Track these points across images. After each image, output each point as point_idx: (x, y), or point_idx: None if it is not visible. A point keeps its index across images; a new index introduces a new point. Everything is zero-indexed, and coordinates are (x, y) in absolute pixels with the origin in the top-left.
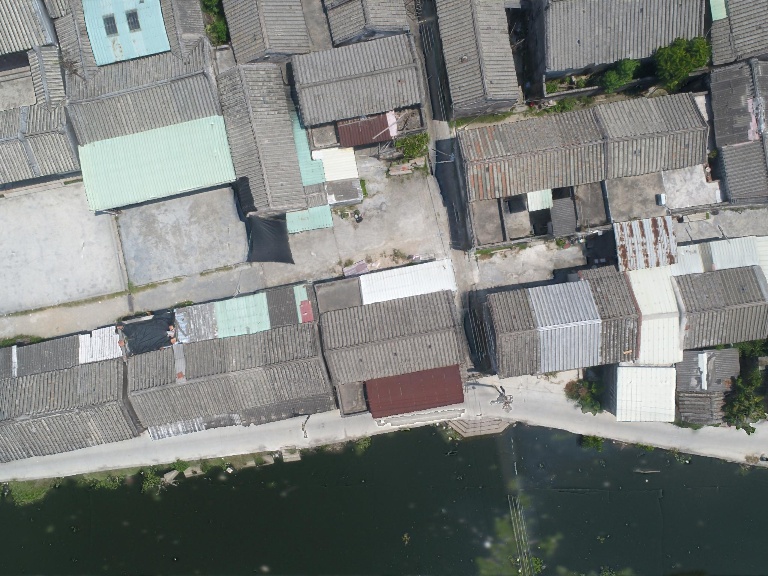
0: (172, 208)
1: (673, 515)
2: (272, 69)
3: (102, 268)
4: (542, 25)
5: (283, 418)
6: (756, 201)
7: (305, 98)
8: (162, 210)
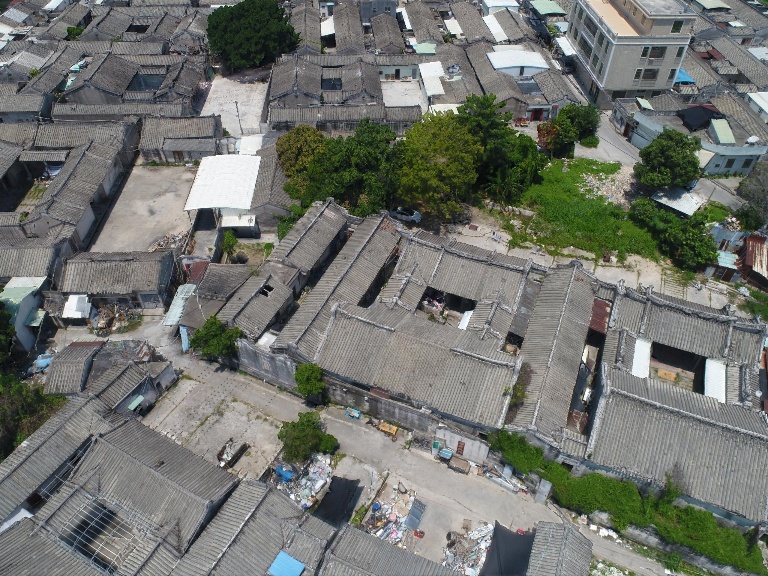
0: None
1: None
2: None
3: None
4: None
5: None
6: None
7: None
8: None
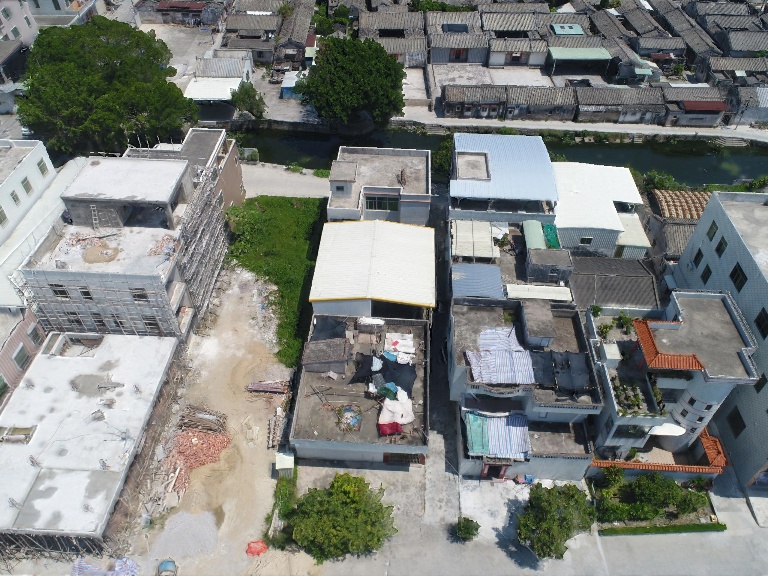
0: (575, 77)
1: None
2: (623, 41)
3: None
4: None
5: (641, 112)
6: None
7: (641, 41)
8: (571, 77)
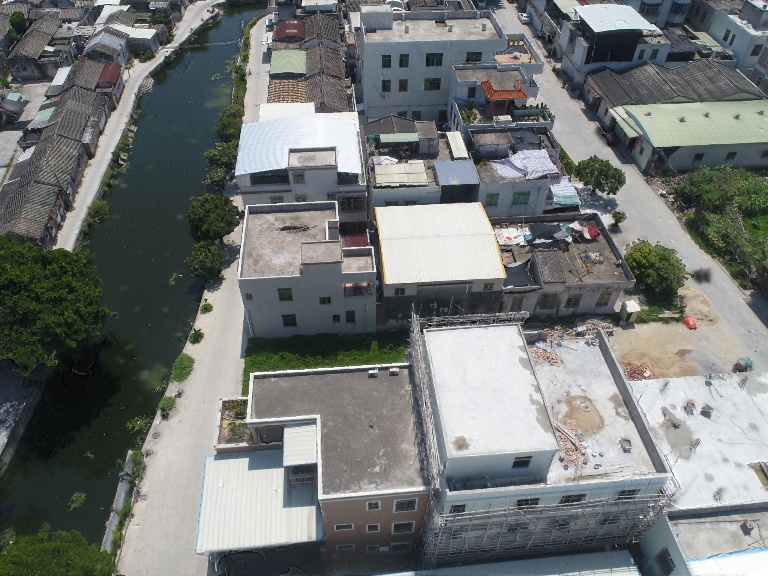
0: None
1: None
2: None
3: None
4: None
5: (103, 109)
6: (83, 13)
7: None
8: None
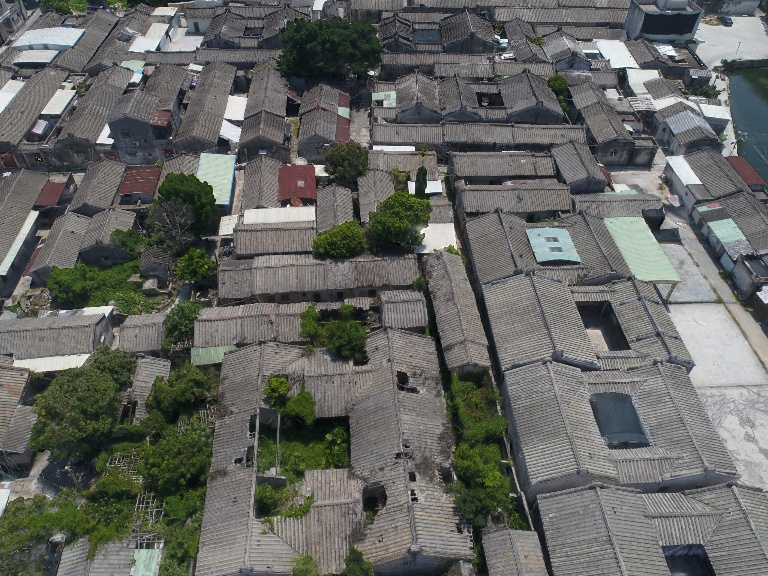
0: None
1: (764, 132)
2: None
3: (710, 314)
4: (545, 112)
5: None
6: None
7: None
8: None
